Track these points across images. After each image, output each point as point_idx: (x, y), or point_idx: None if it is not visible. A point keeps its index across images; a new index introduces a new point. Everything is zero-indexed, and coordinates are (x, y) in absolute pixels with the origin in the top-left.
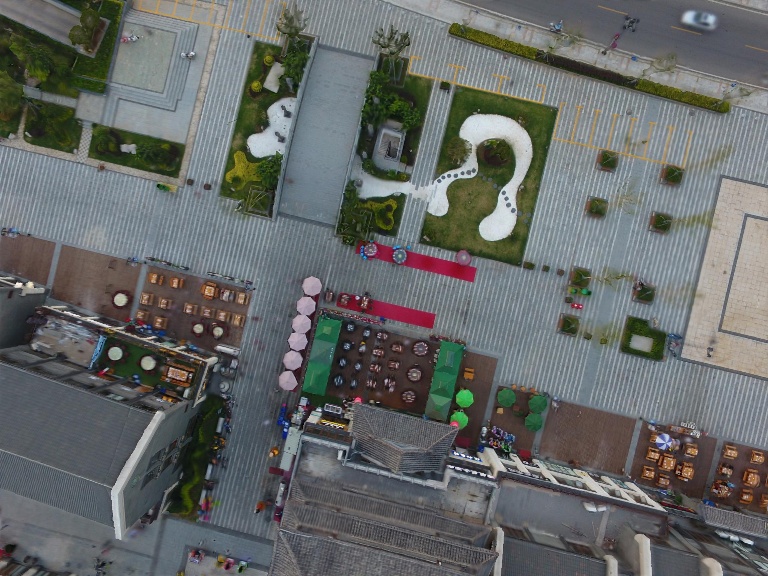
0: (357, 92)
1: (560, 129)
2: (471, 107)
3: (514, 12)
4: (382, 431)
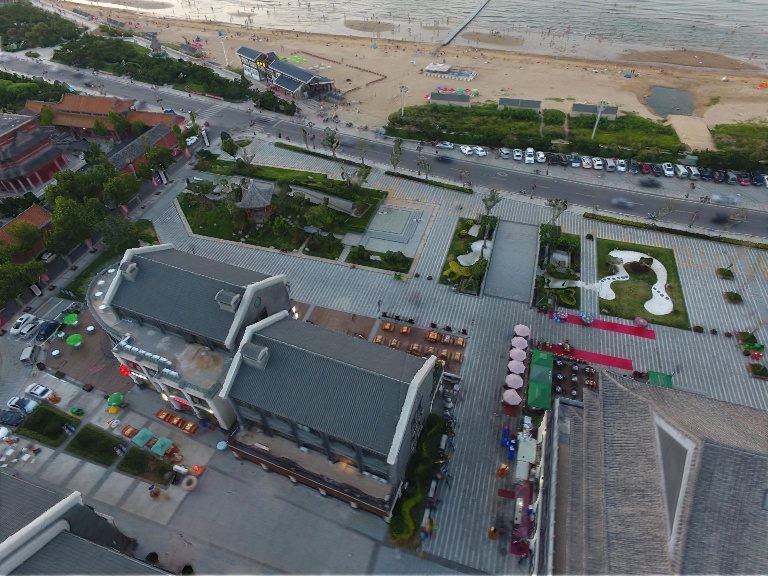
0: (531, 237)
1: (680, 259)
2: (611, 246)
3: (621, 211)
4: None
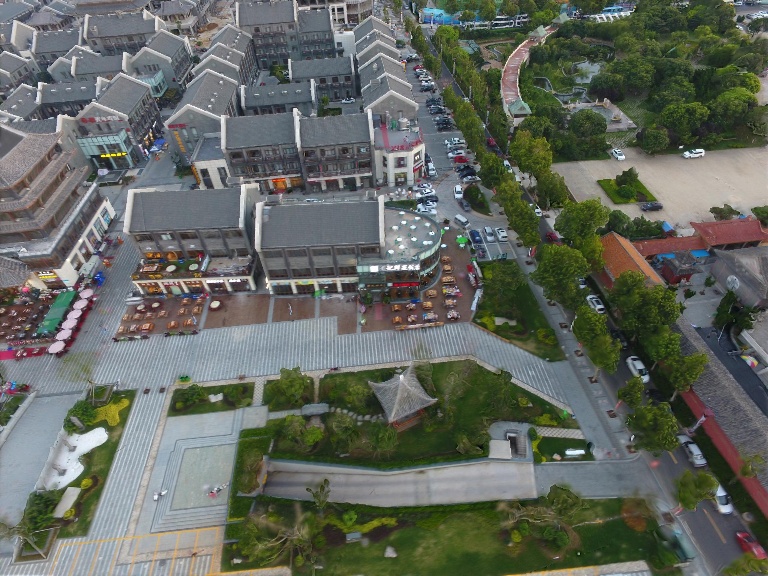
0: None
1: None
2: None
3: None
4: (4, 275)
